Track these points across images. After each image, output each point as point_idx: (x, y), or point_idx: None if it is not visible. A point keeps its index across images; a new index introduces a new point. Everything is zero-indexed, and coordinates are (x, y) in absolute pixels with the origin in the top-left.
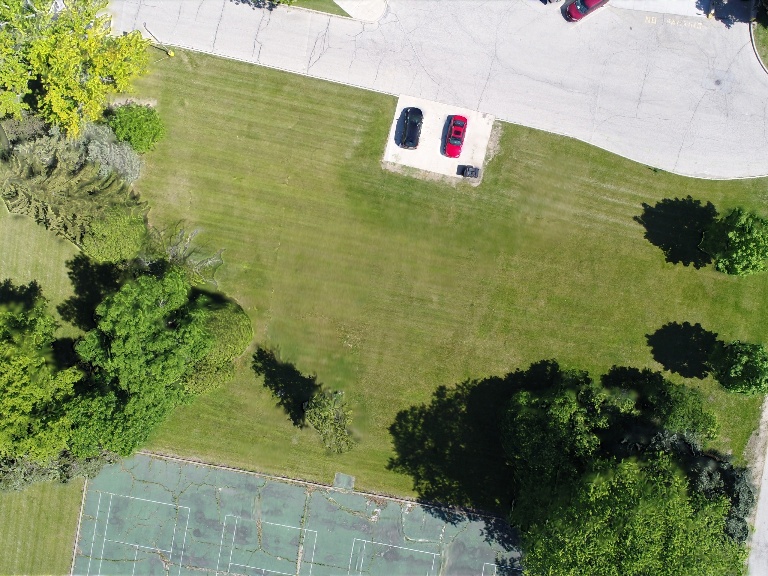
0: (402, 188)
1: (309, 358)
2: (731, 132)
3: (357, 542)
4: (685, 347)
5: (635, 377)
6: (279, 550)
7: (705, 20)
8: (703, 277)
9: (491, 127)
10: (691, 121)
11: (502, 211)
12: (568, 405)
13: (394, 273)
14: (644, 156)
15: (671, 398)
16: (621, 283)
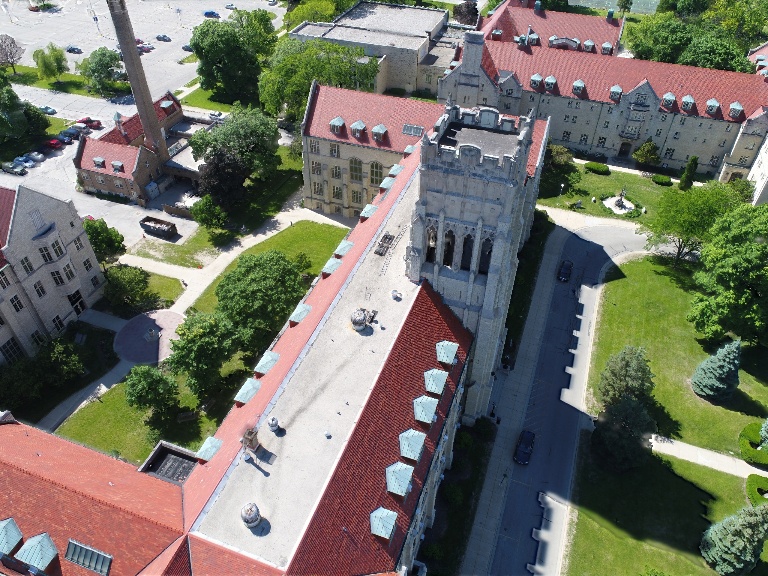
0: None
1: (631, 23)
2: None
3: (609, 5)
4: None
5: None
6: (634, 6)
7: None
8: None
9: None
10: None
11: None
12: None
13: None
14: None
15: None
16: None
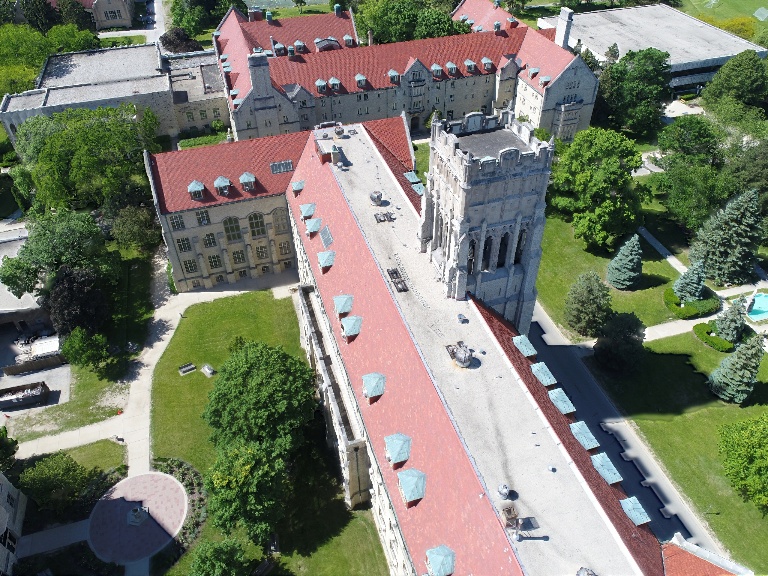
0: None
1: None
2: None
3: None
4: None
5: None
6: None
7: None
8: (197, 40)
9: None
10: None
11: None
12: None
13: None
14: None
15: None
16: None
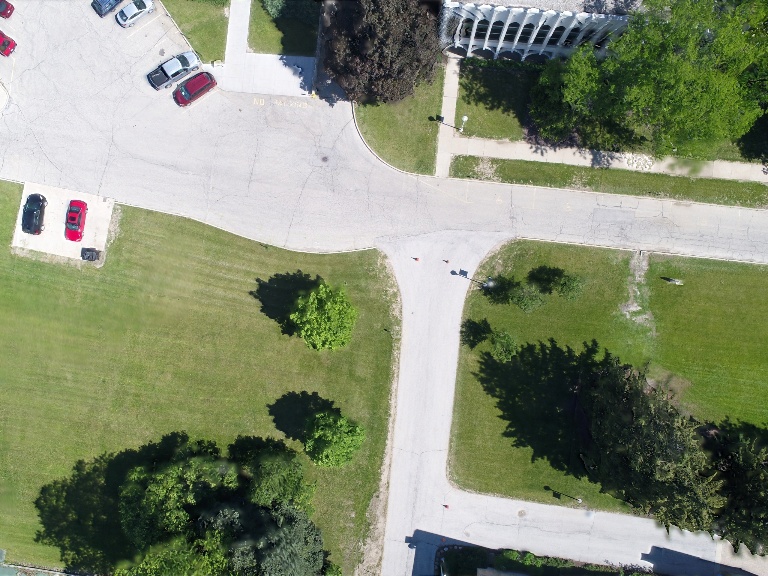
0: (31, 272)
1: None
2: (337, 207)
3: None
4: (304, 415)
5: (260, 445)
6: None
7: (310, 100)
8: None
9: (111, 210)
10: (300, 198)
11: (125, 291)
12: (166, 481)
13: (30, 353)
14: (256, 233)
15: (262, 471)
16: (241, 356)
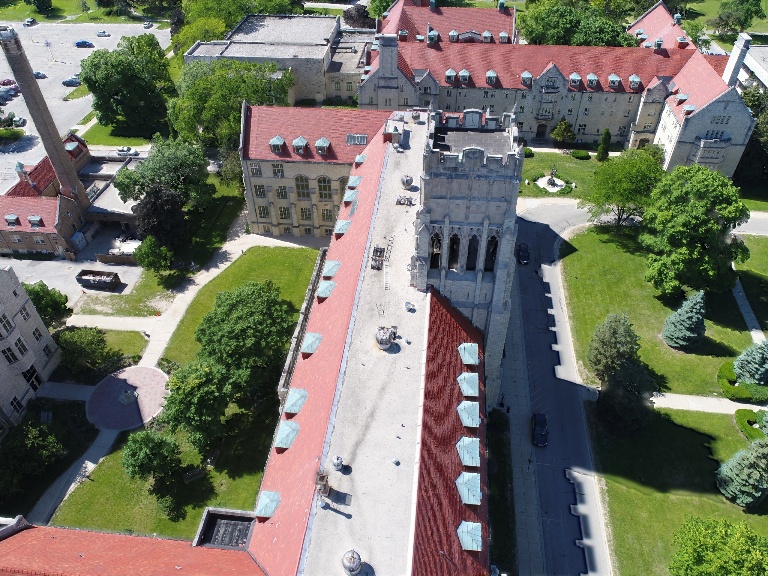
0: None
1: None
2: None
3: None
4: None
5: None
6: None
7: None
8: None
9: None
10: None
11: None
12: None
13: None
14: None
15: None
16: None
